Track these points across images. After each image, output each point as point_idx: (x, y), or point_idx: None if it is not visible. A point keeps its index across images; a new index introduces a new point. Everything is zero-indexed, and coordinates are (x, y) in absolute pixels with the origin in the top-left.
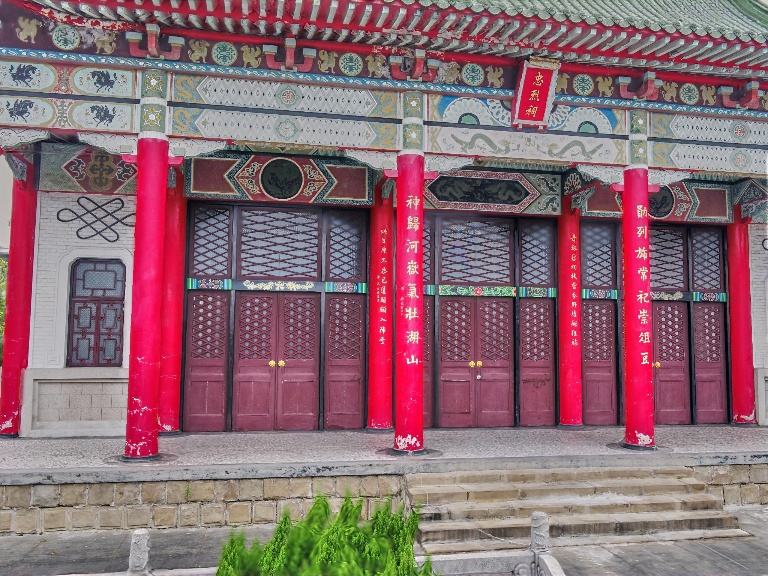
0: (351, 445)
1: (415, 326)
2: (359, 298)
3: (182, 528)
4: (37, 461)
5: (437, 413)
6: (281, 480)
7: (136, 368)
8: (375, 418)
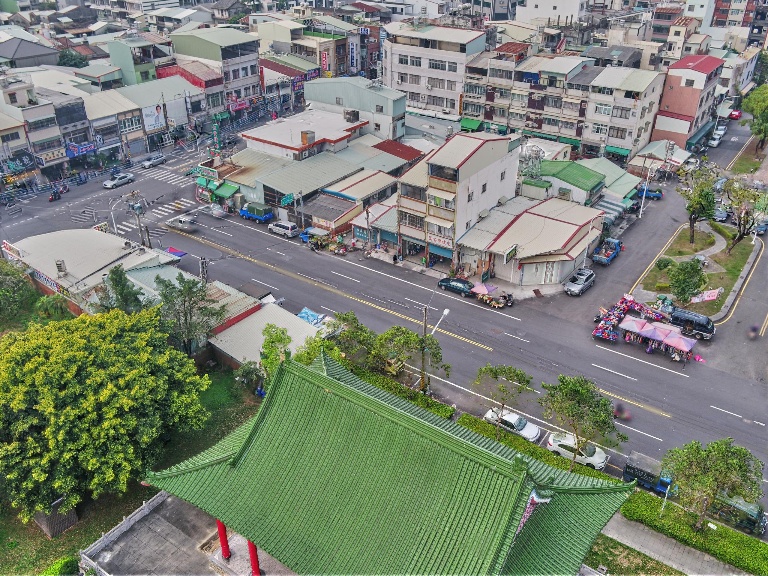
0: None
1: None
2: None
3: None
4: (240, 565)
5: None
6: None
7: (251, 564)
8: None
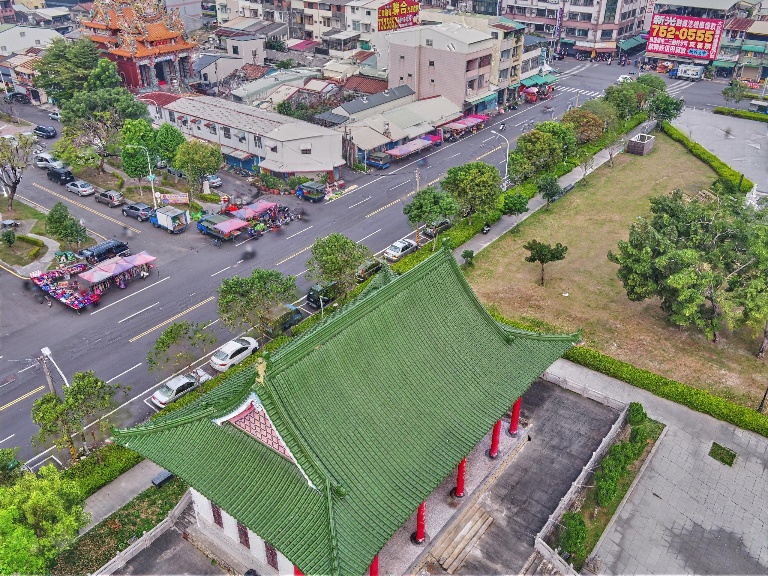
0: (399, 541)
1: None
2: None
3: None
4: None
5: None
6: None
7: None
8: None
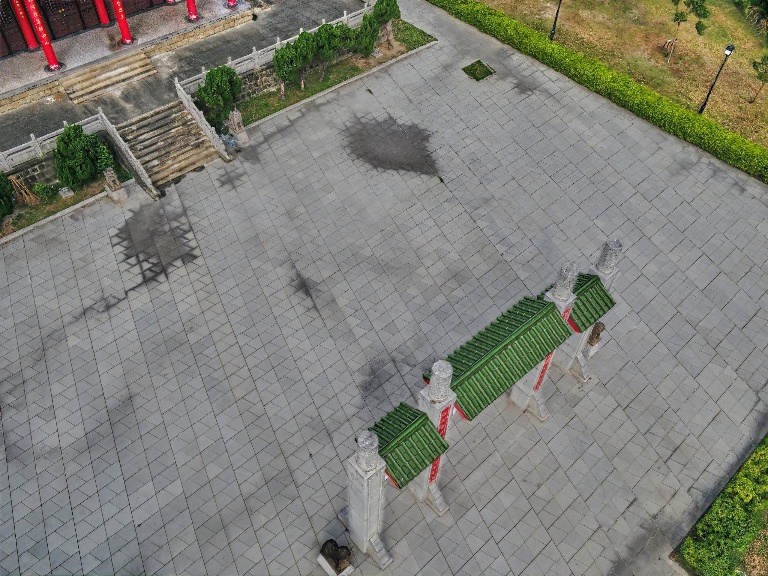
0: (33, 66)
1: (44, 32)
2: (5, 0)
3: (2, 113)
4: None
5: (53, 34)
6: (23, 93)
7: None
8: (31, 45)
